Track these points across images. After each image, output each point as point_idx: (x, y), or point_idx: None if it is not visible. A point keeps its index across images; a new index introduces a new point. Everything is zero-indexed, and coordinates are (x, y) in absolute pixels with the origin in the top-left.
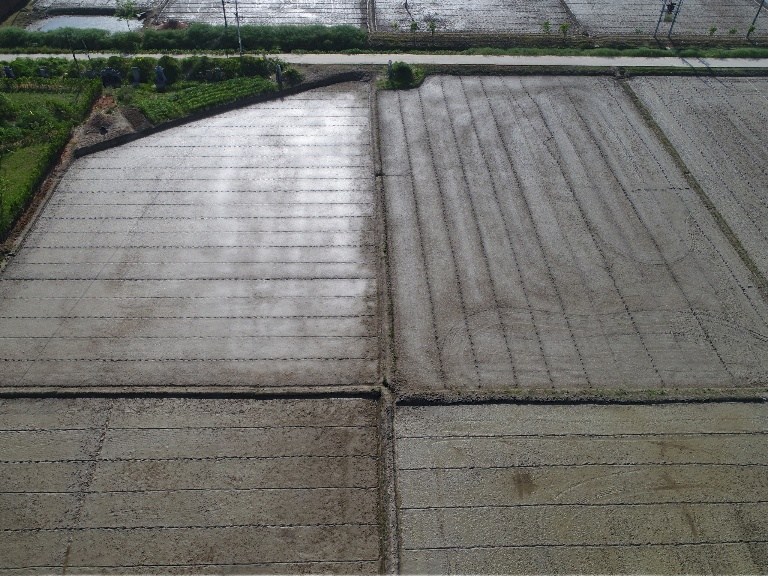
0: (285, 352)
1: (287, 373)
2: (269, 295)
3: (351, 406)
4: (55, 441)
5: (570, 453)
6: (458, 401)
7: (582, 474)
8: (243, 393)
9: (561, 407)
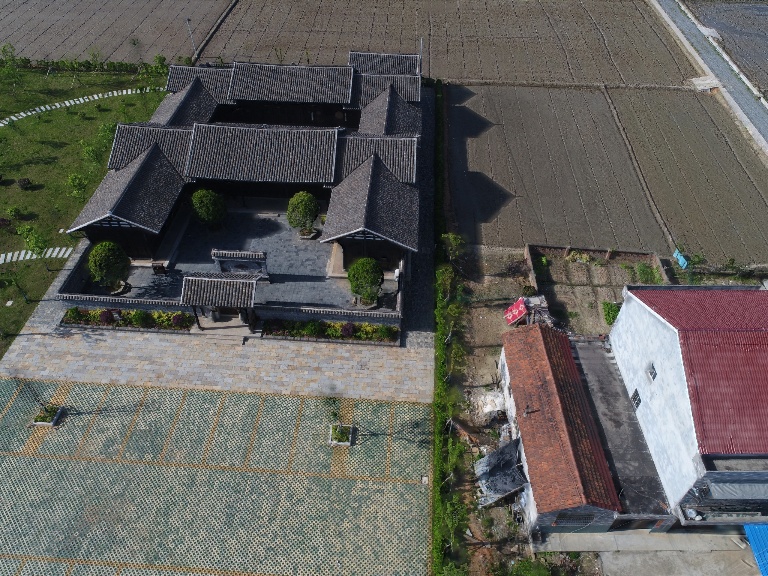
0: (212, 1)
1: (224, 1)
2: (171, 4)
3: None
4: None
5: None
6: None
7: None
8: (231, 7)
9: None
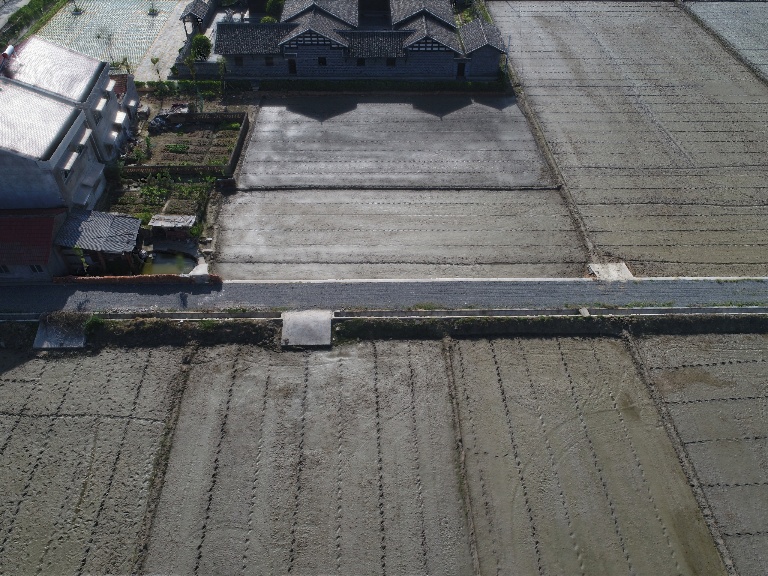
0: None
1: None
2: None
3: (663, 3)
4: (551, 8)
5: (761, 10)
6: (709, 0)
7: (767, 13)
8: None
9: (752, 2)
